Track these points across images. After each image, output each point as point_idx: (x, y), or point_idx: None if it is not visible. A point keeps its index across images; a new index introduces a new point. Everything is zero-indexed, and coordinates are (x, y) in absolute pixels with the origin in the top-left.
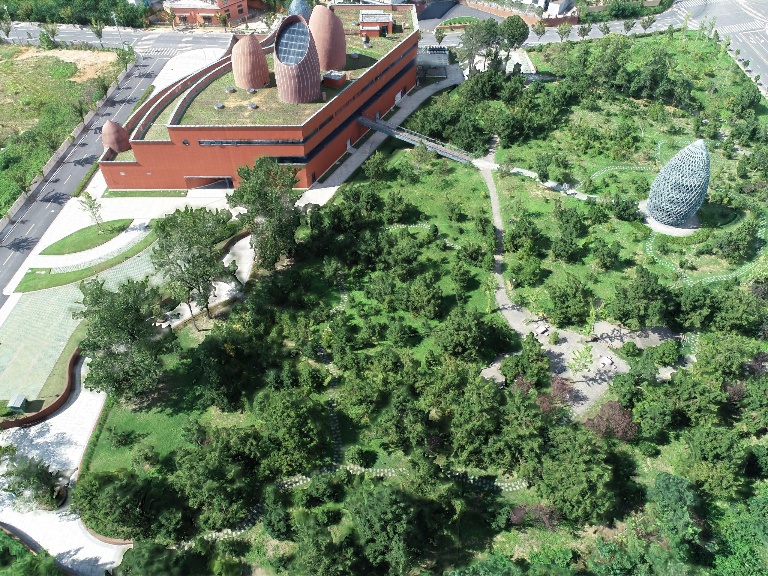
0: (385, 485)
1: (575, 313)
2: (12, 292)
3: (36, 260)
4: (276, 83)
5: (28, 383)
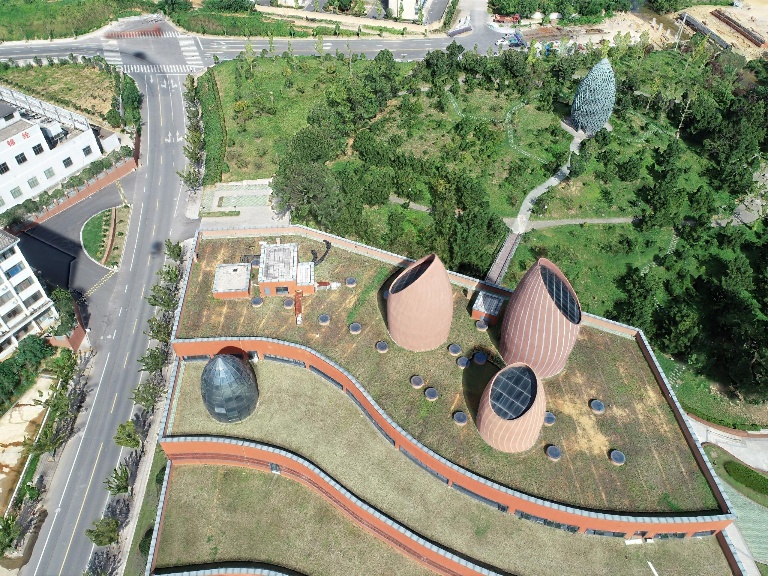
0: None
1: None
2: None
3: None
4: (548, 367)
5: None
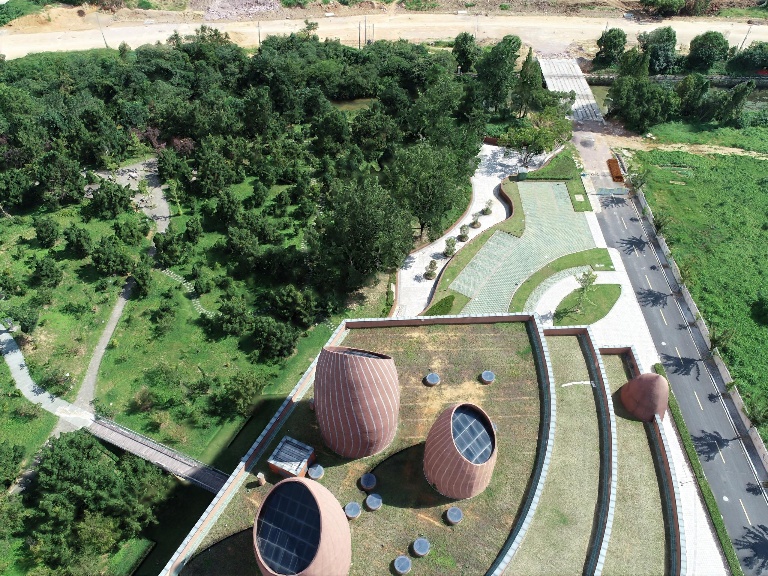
0: (281, 97)
1: (117, 184)
2: (608, 249)
3: (618, 279)
4: None
5: (530, 190)
